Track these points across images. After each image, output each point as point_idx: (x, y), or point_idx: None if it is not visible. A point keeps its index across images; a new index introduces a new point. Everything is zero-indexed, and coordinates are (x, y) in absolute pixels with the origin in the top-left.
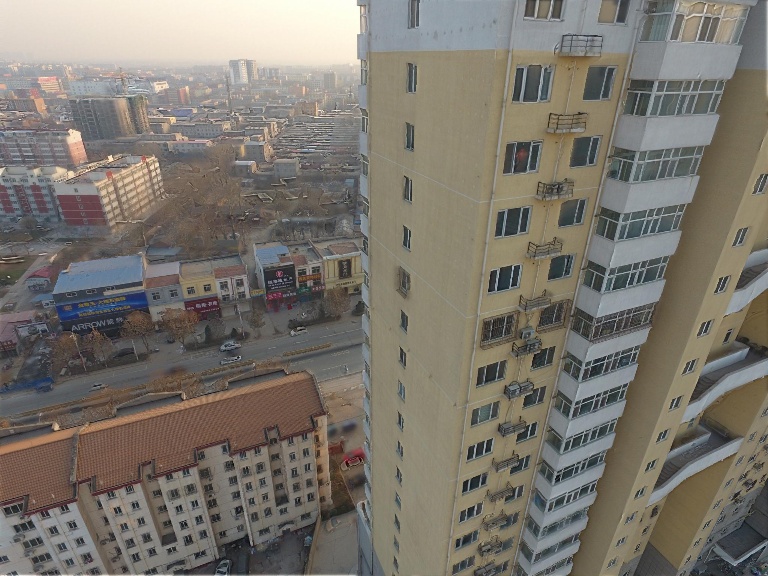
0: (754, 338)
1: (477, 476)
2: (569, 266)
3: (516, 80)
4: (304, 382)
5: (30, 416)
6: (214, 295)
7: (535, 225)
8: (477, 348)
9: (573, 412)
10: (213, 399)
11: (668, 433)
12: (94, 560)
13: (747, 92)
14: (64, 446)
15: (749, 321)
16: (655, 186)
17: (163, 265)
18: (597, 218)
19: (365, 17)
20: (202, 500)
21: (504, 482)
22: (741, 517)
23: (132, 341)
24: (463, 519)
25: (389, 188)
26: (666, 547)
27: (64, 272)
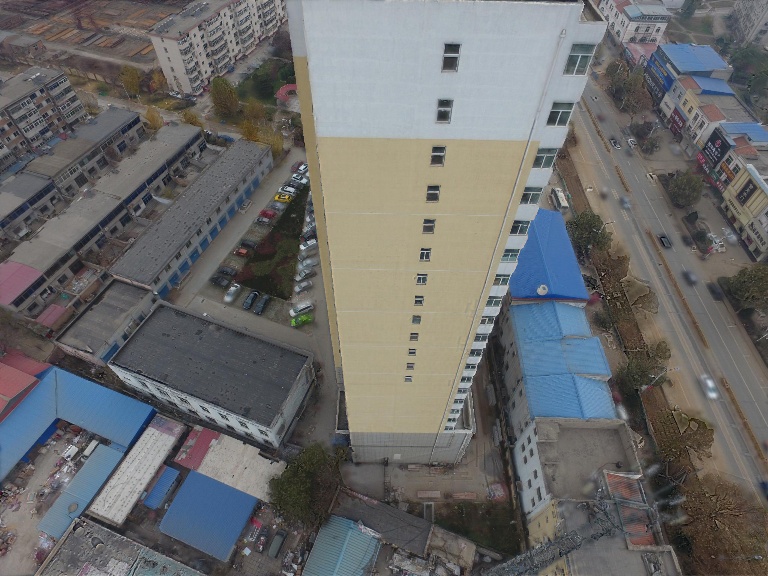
0: None
1: None
2: None
3: None
4: None
5: None
6: (686, 118)
7: None
8: None
9: None
10: None
11: None
12: None
13: None
14: None
15: None
16: None
17: (725, 86)
18: None
19: None
20: None
21: None
22: None
23: None
24: None
25: None
26: None
27: (692, 44)
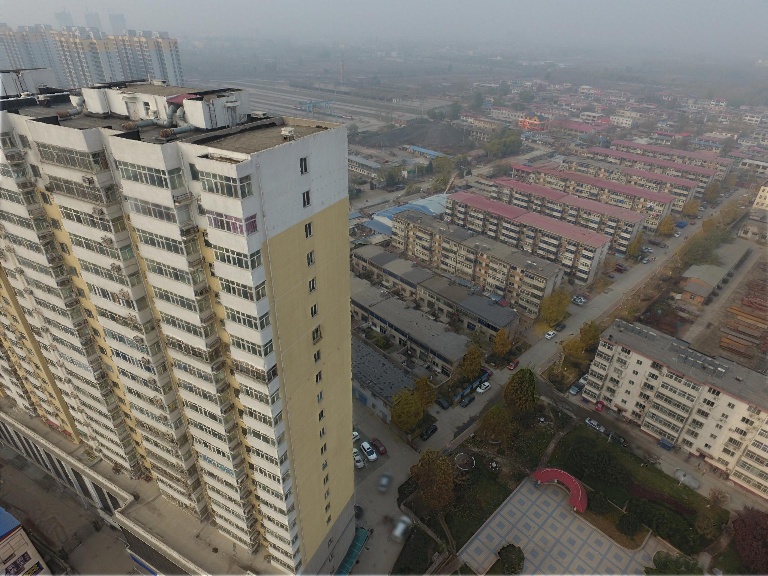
0: None
1: None
2: None
3: None
4: None
5: None
6: None
7: None
8: None
9: None
10: None
11: None
12: None
13: None
14: None
15: None
16: None
17: None
18: None
19: (248, 223)
20: None
21: None
22: None
23: None
24: None
25: None
26: None
27: None
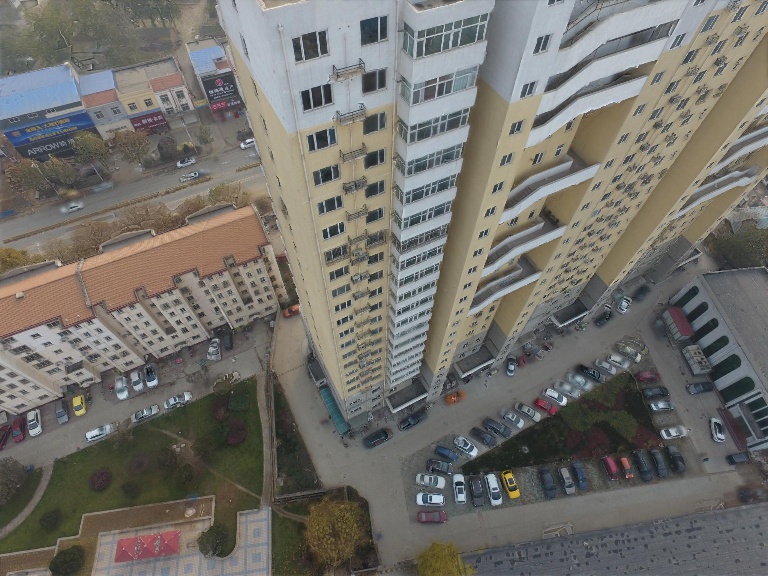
0: (554, 212)
1: (346, 317)
2: (382, 213)
3: (309, 141)
4: (250, 218)
5: (26, 238)
6: (157, 110)
7: (347, 203)
8: (324, 266)
9: (400, 284)
10: (178, 236)
11: (472, 284)
12: (122, 347)
13: (493, 105)
14: (72, 281)
15: (552, 201)
16: (426, 174)
17: (95, 76)
18: (394, 189)
19: None
20: (187, 307)
21: (366, 316)
22: (573, 298)
23: (91, 164)
24: (342, 336)
25: (263, 143)
26: (503, 325)
27: None
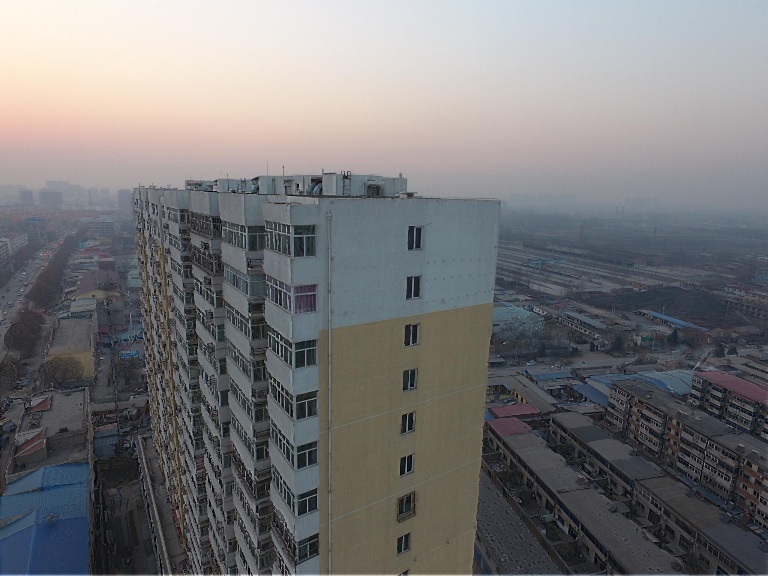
0: None
1: None
2: None
3: None
4: None
5: None
6: None
7: None
8: None
9: None
10: None
11: None
12: None
13: None
14: None
15: None
16: None
17: None
18: None
19: (301, 296)
20: None
21: None
22: None
23: None
24: None
25: (375, 442)
26: None
27: None
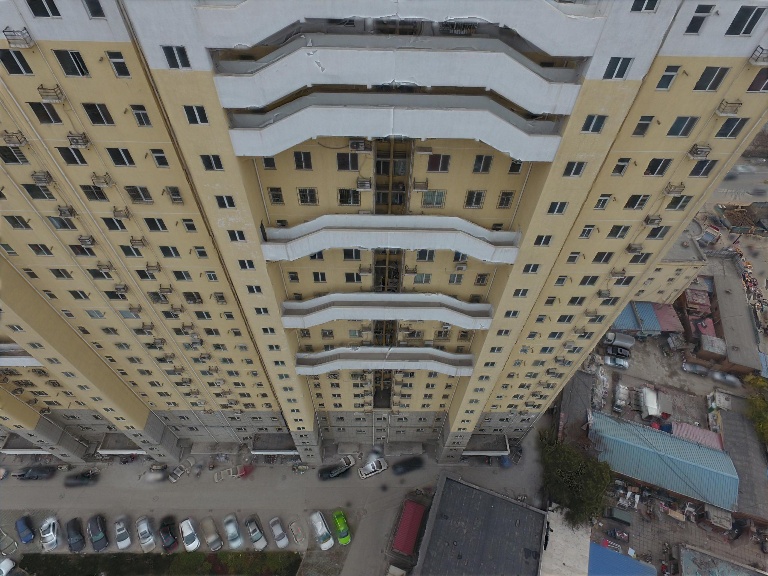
0: None
1: None
2: None
3: None
4: None
5: None
6: None
7: None
8: None
9: None
10: None
11: None
12: None
13: None
14: None
15: None
16: None
17: None
18: None
19: None
20: None
21: None
22: (275, 426)
23: None
24: None
25: None
26: None
27: None
